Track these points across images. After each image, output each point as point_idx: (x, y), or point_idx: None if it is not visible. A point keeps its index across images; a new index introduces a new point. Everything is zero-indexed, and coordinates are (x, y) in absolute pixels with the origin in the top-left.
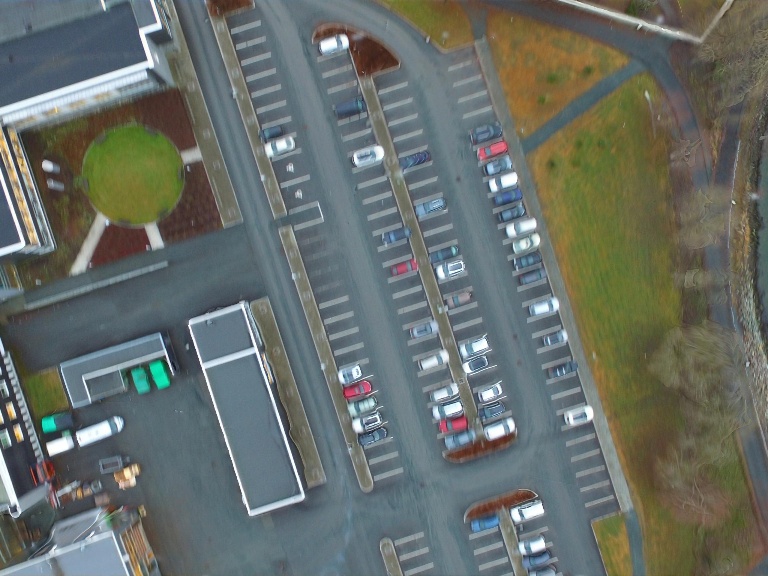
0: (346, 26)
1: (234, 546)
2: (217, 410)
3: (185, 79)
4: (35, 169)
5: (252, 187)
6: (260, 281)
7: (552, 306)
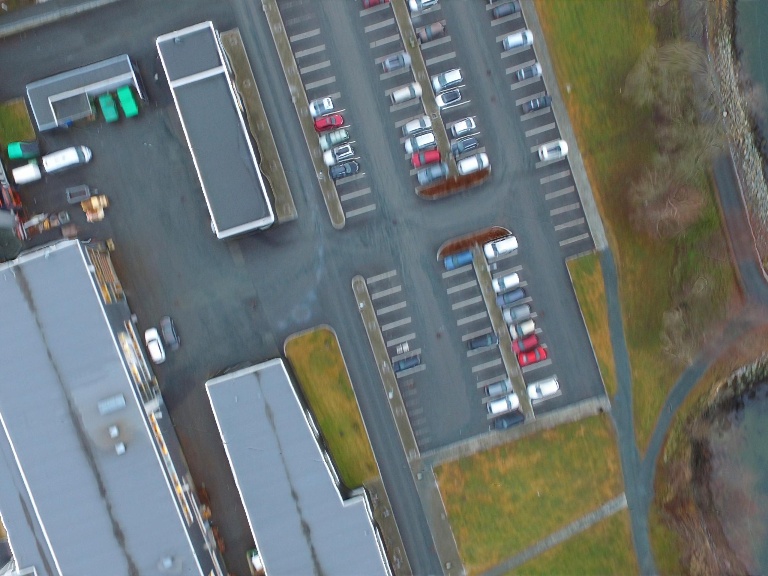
0: None
1: (204, 282)
2: (185, 130)
3: None
4: None
5: None
6: (230, 12)
7: (526, 38)
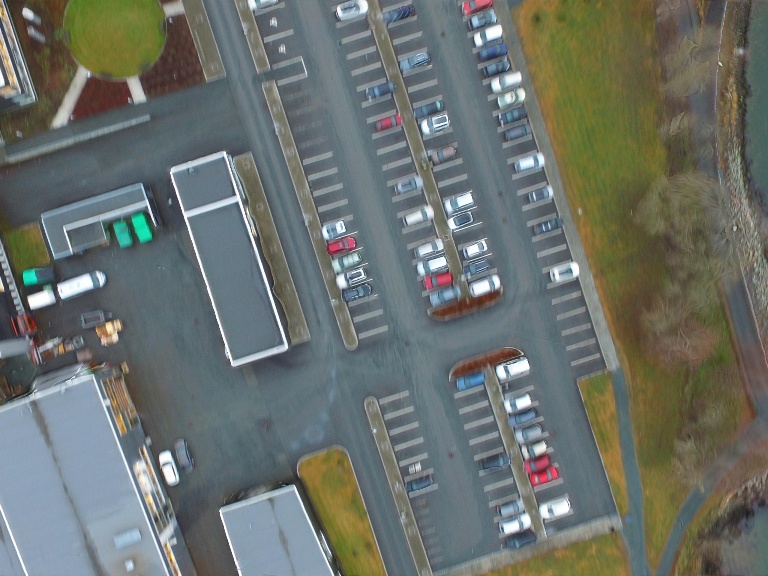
0: None
1: (217, 404)
2: (199, 259)
3: None
4: (16, 20)
5: (235, 41)
6: (243, 136)
7: (537, 161)
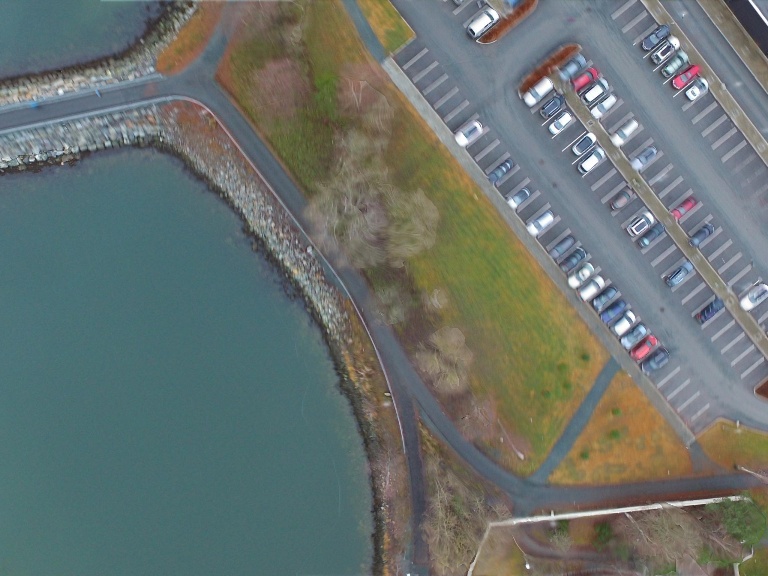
0: None
1: None
2: None
3: None
4: None
5: None
6: None
7: (537, 226)
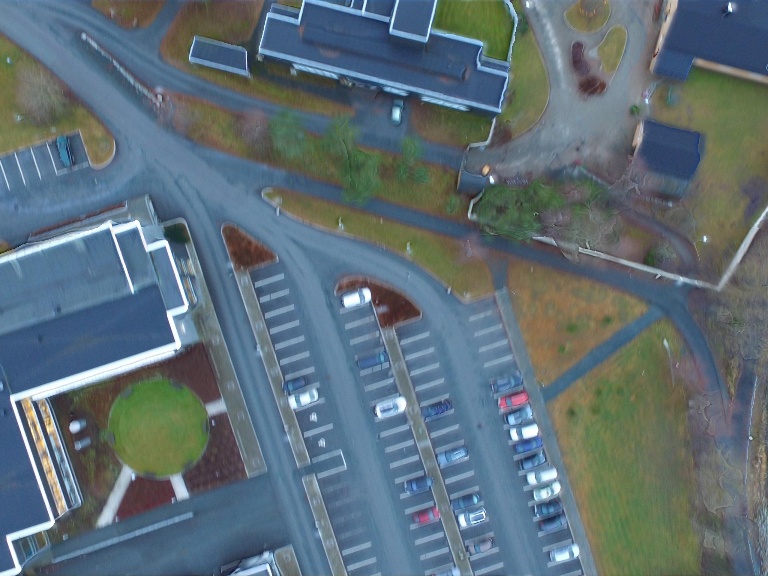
0: (368, 278)
1: None
2: None
3: (210, 333)
4: (62, 425)
5: (276, 437)
6: (284, 529)
7: (573, 553)
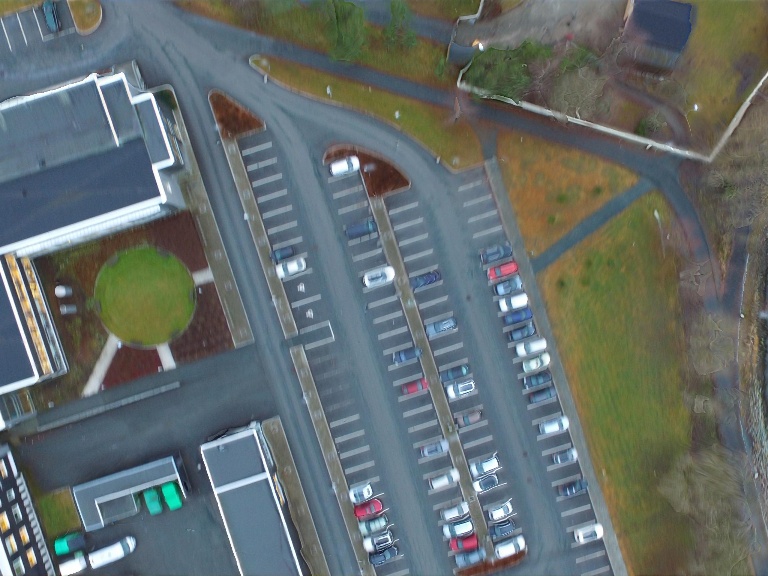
0: (357, 147)
1: None
2: (229, 535)
3: (197, 201)
4: (48, 292)
5: (263, 307)
6: (271, 400)
7: (562, 425)
